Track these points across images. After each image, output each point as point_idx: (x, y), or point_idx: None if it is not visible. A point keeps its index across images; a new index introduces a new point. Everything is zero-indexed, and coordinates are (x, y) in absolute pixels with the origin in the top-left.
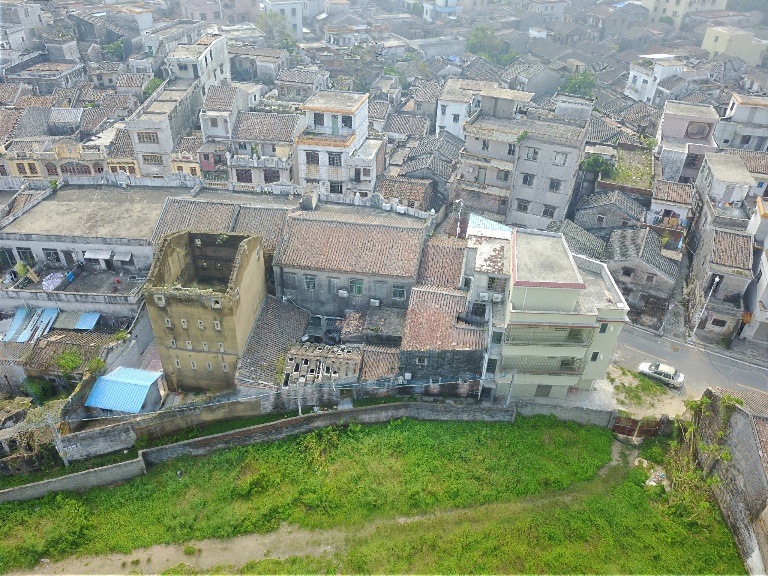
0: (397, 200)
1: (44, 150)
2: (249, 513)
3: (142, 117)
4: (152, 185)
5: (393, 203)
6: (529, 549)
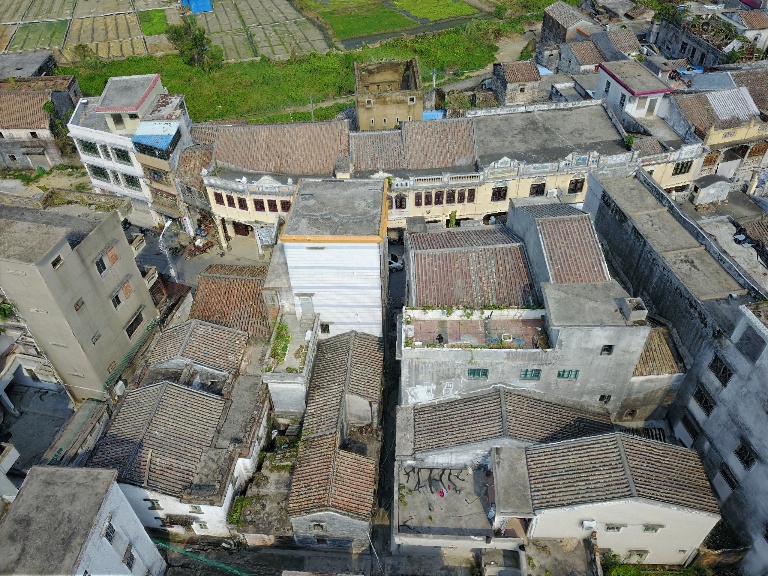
0: (243, 179)
1: (759, 201)
2: (329, 108)
3: (654, 200)
4: (538, 170)
5: (248, 183)
6: (192, 116)
